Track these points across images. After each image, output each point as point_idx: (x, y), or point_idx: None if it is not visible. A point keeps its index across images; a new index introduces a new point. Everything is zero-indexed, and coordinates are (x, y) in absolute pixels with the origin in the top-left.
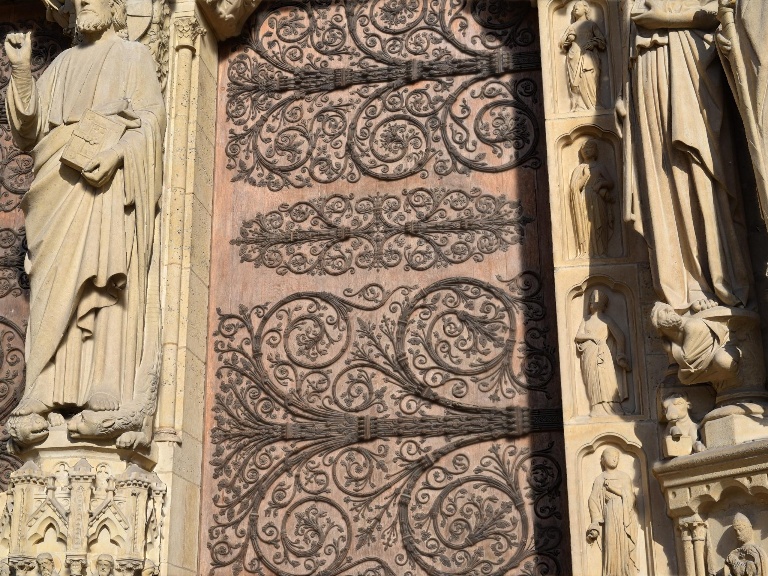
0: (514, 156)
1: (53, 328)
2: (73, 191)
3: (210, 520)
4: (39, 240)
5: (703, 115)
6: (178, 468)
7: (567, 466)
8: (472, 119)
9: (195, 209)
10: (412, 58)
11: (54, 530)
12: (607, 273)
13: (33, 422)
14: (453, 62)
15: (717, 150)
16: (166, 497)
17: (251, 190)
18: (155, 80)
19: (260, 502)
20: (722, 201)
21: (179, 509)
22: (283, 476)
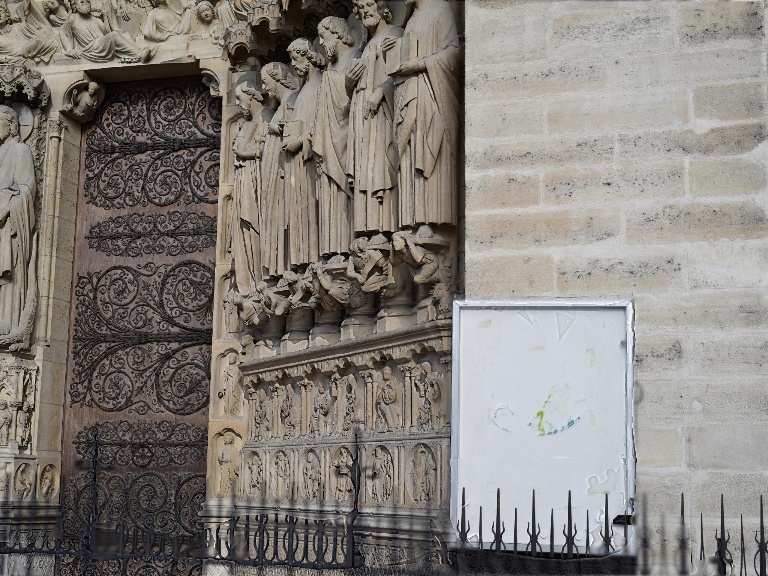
0: None
1: None
2: None
3: (71, 380)
4: None
5: None
6: (48, 357)
7: (212, 363)
8: (204, 173)
9: (61, 224)
10: (177, 137)
11: None
12: None
13: None
14: (196, 140)
15: None
16: (39, 372)
17: (96, 209)
18: (31, 165)
19: (94, 372)
20: None
21: (49, 377)
22: (105, 360)
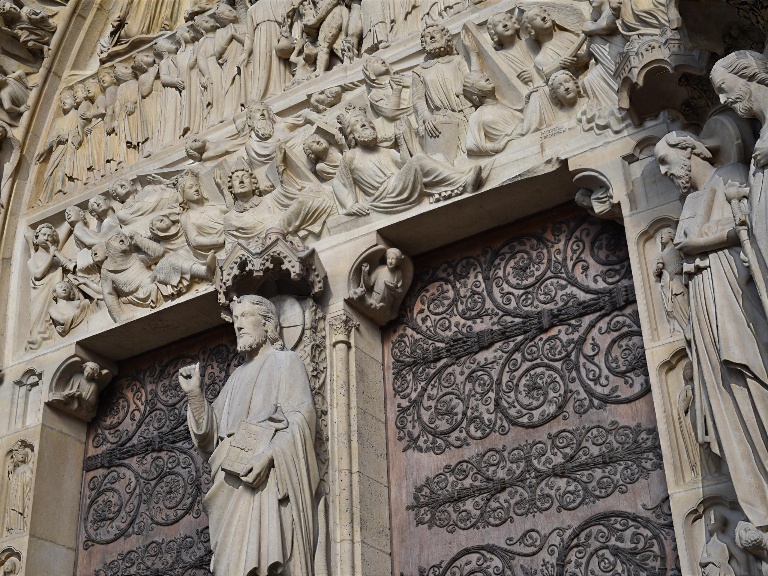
0: (644, 383)
1: None
2: (237, 494)
3: None
4: (215, 541)
5: (751, 329)
6: None
7: None
8: (602, 355)
9: (363, 486)
10: (543, 308)
11: None
12: (719, 492)
13: None
14: (578, 304)
15: None
16: None
17: (419, 457)
18: (303, 381)
19: None
20: None
21: None
22: None
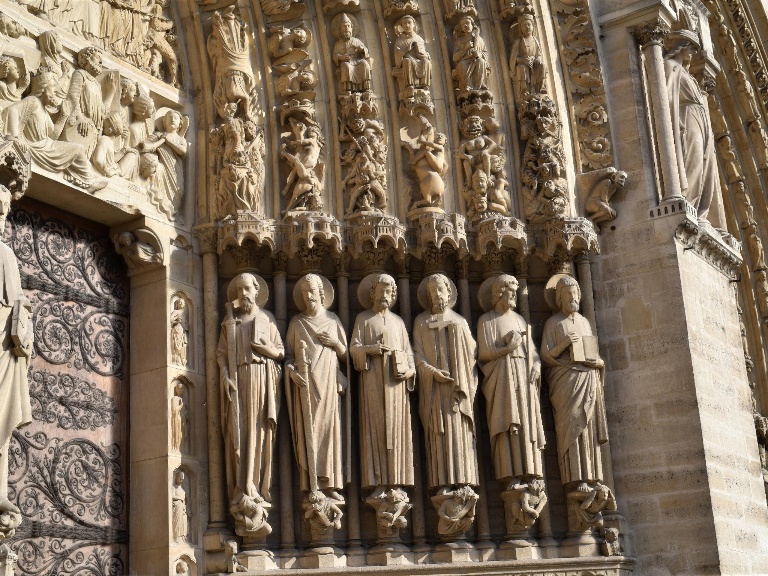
0: (112, 368)
1: None
2: (6, 356)
3: None
4: None
5: (275, 406)
6: None
7: (170, 570)
8: (94, 337)
9: None
10: None
11: None
12: (188, 464)
13: None
14: (89, 296)
15: None
16: None
17: None
18: None
19: None
20: None
21: None
22: None
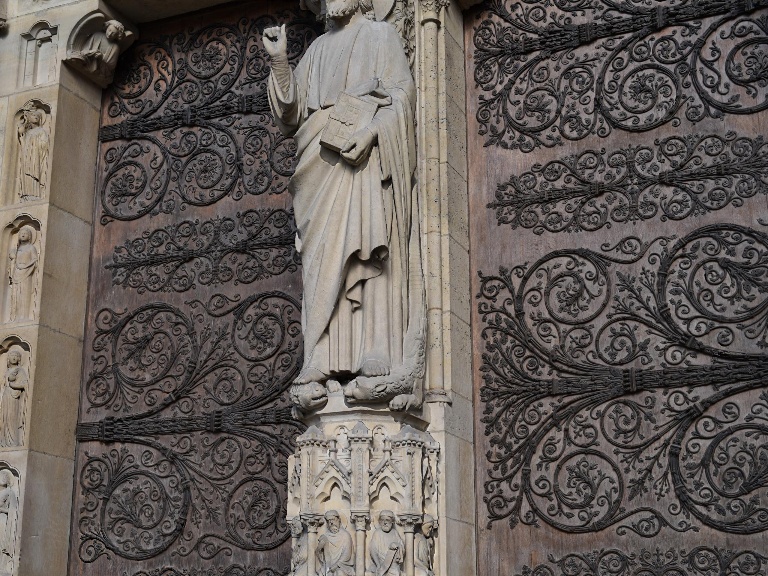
0: None
1: (325, 301)
2: (334, 171)
3: (485, 475)
4: (306, 220)
5: None
6: (450, 427)
7: None
8: (723, 61)
9: (450, 177)
10: (657, 5)
11: (339, 489)
12: None
13: (313, 390)
14: (699, 4)
15: None
16: (440, 455)
17: (504, 153)
18: (403, 57)
19: (531, 457)
20: None
21: (454, 466)
22: (552, 431)
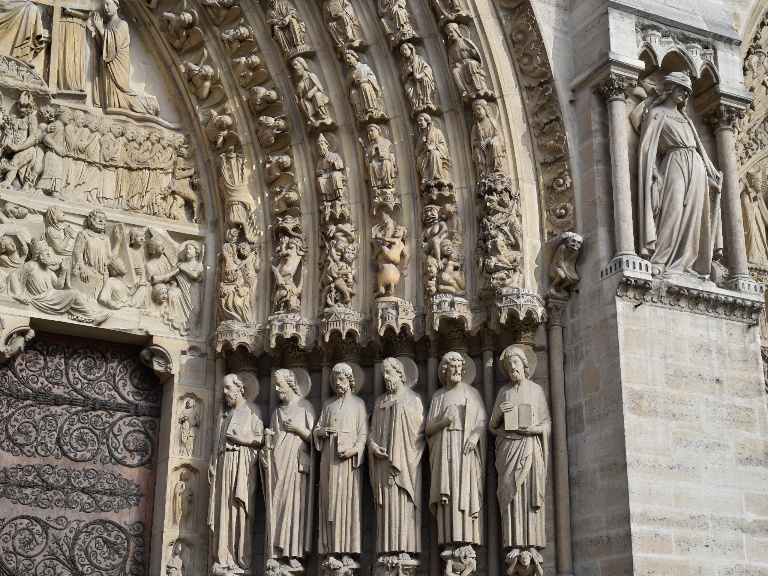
0: (140, 460)
1: None
2: None
3: None
4: None
5: (248, 486)
6: None
7: None
8: (123, 436)
9: None
10: (97, 397)
11: None
12: (186, 537)
13: None
14: (118, 404)
15: (251, 502)
16: None
17: (2, 453)
18: None
19: None
20: (248, 523)
21: None
22: None
